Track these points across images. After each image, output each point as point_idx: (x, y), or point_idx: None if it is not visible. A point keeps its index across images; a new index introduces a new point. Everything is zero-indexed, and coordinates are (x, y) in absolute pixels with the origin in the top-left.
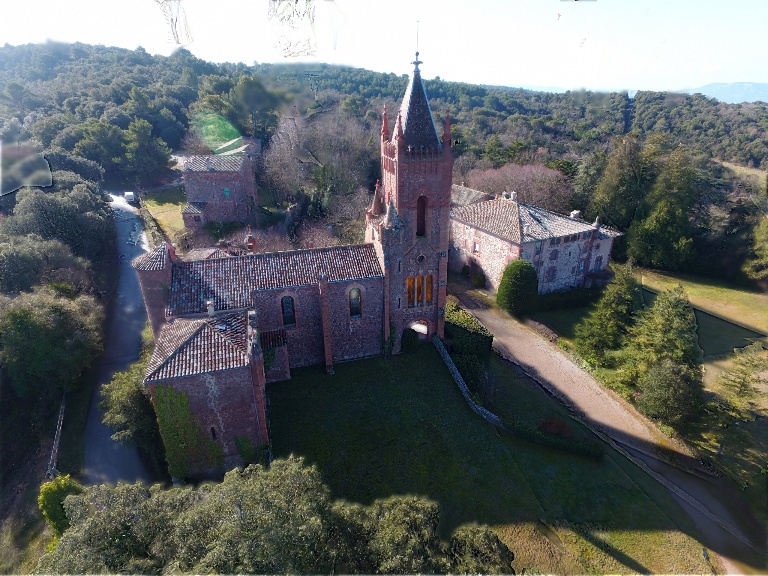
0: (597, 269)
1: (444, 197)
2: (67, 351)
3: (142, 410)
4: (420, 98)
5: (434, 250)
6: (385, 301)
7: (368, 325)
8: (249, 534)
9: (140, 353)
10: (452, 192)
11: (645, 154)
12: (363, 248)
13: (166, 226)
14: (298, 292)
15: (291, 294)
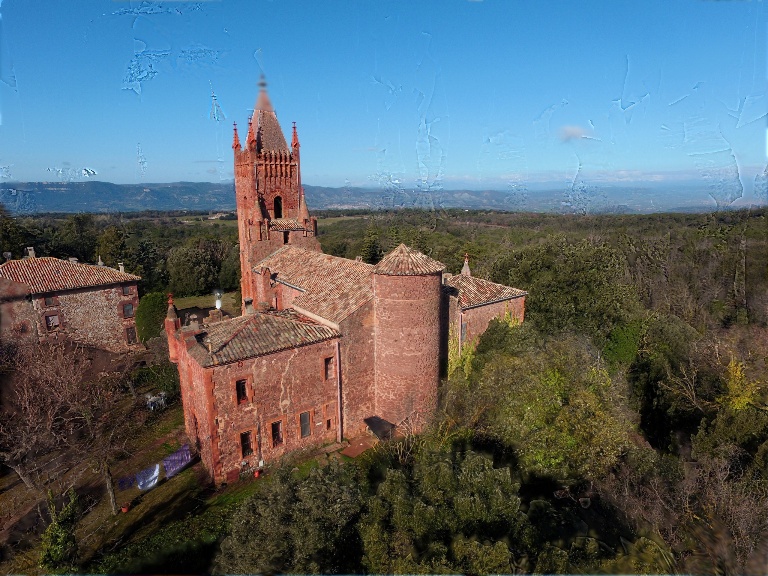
0: None
1: None
2: None
3: None
4: None
5: None
6: None
7: None
8: None
9: None
10: None
11: None
12: None
13: None
14: None
15: None
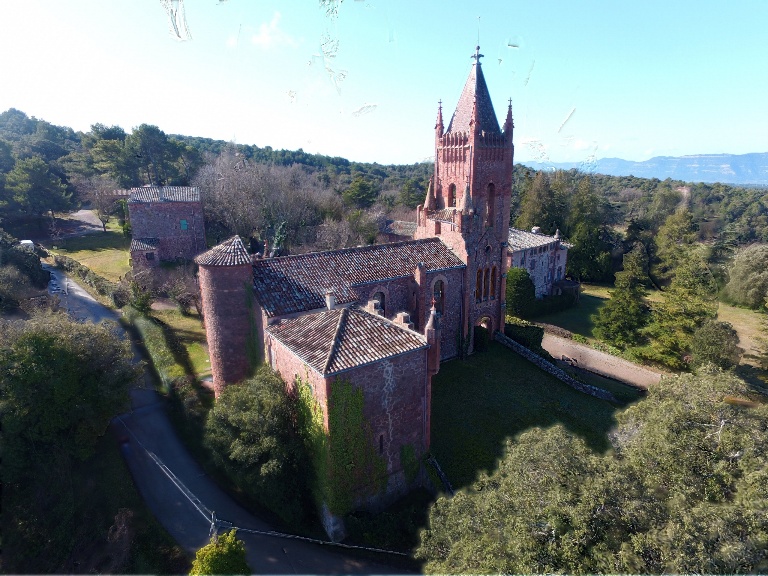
0: (558, 279)
1: (507, 185)
2: (112, 387)
3: (287, 430)
4: (483, 89)
5: (498, 240)
6: (466, 293)
7: (448, 323)
8: (767, 434)
9: (181, 392)
10: (398, 227)
11: (553, 187)
12: (431, 242)
13: (98, 272)
14: (389, 287)
15: (383, 289)
